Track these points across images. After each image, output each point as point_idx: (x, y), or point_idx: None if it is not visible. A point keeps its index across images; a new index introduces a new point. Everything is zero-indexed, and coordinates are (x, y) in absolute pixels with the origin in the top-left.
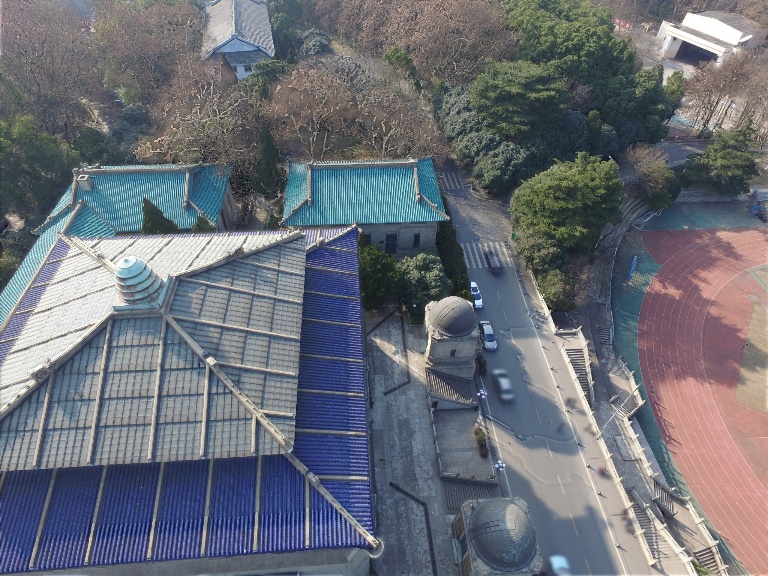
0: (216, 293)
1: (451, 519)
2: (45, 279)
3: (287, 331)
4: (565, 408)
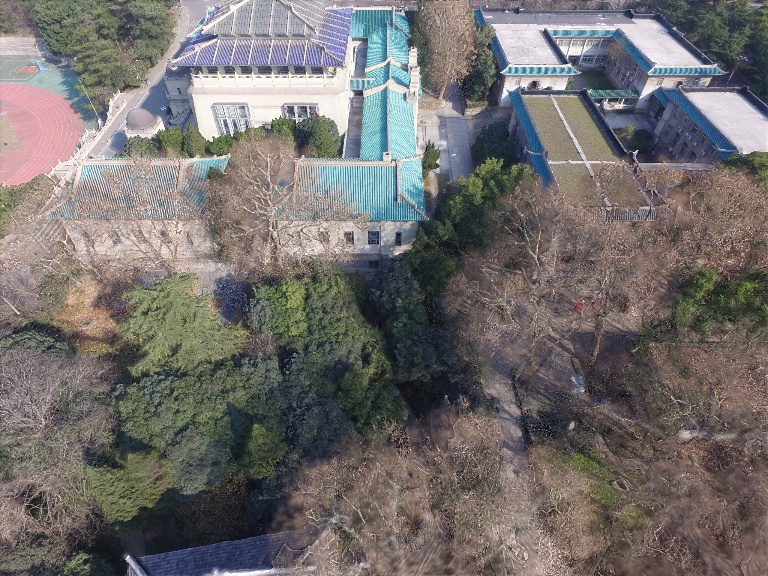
0: None
1: None
2: (339, 49)
3: None
4: (108, 142)
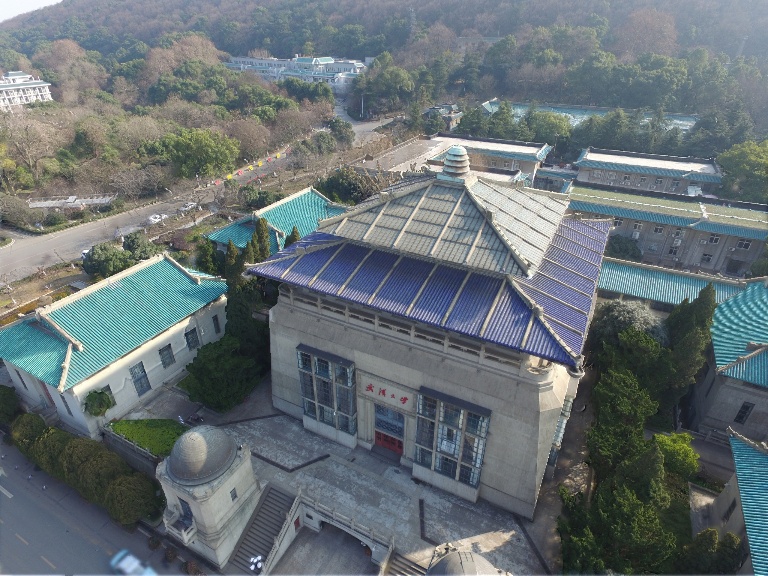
0: (449, 206)
1: (262, 484)
2: None
3: (404, 241)
4: None
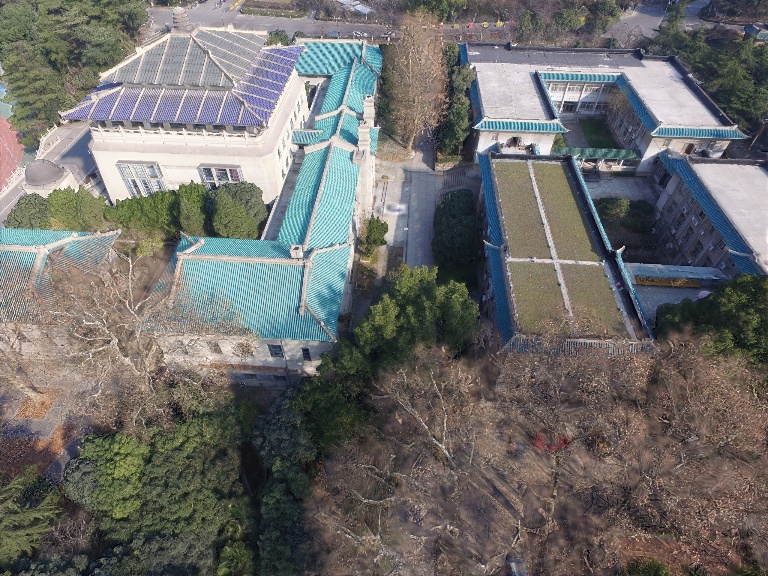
0: None
1: None
2: (267, 102)
3: None
4: None
